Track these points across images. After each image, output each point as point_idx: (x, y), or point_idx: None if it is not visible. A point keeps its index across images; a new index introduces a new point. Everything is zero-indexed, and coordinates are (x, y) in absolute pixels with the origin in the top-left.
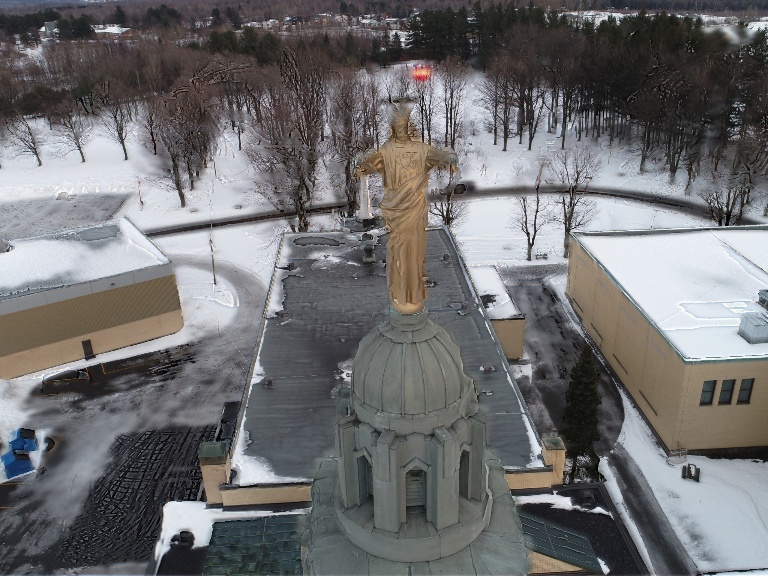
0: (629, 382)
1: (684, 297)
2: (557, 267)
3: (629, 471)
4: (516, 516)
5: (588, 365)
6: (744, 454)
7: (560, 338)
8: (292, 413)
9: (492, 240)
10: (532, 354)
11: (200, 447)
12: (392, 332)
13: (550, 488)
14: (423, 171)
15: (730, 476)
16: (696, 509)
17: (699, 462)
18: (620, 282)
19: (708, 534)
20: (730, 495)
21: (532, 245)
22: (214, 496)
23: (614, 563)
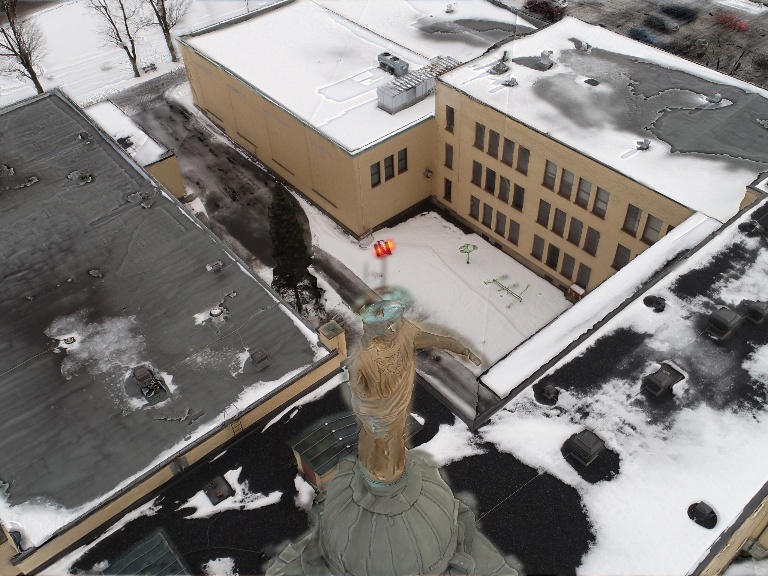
0: (298, 183)
1: (318, 82)
2: (171, 76)
3: (335, 270)
4: (484, 539)
5: (284, 203)
6: (413, 212)
7: (212, 157)
8: (33, 423)
9: (84, 63)
10: (194, 186)
11: None
12: (381, 505)
13: (340, 368)
14: (412, 363)
15: (411, 238)
16: (399, 280)
17: (384, 236)
18: (254, 85)
19: (416, 297)
20: (418, 255)
21: (135, 59)
22: (8, 573)
23: (424, 411)
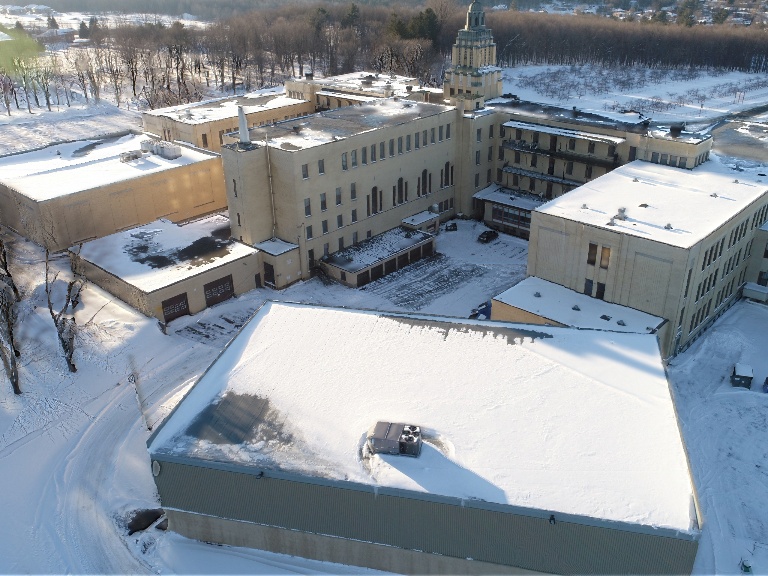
0: None
1: None
2: None
3: None
4: None
5: None
6: None
7: None
8: (424, 112)
9: None
10: None
11: (384, 285)
12: None
13: None
14: None
15: None
16: None
17: None
18: None
19: None
20: None
21: None
22: None
23: None
